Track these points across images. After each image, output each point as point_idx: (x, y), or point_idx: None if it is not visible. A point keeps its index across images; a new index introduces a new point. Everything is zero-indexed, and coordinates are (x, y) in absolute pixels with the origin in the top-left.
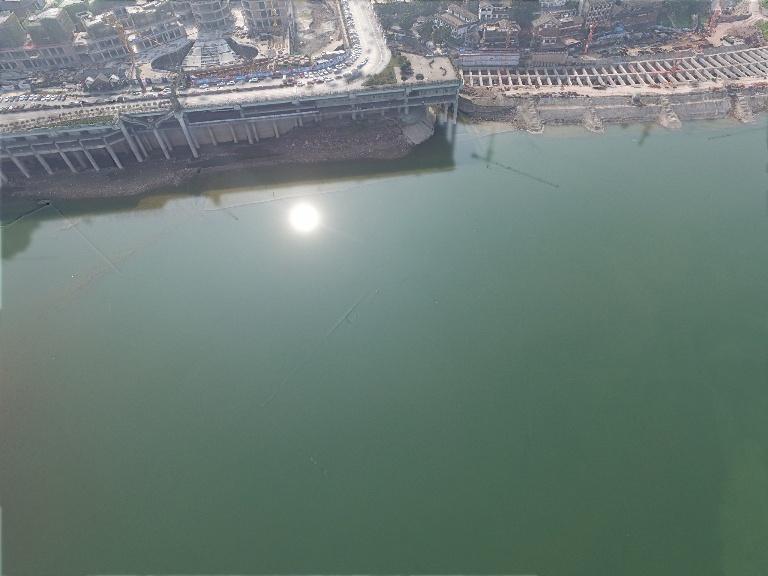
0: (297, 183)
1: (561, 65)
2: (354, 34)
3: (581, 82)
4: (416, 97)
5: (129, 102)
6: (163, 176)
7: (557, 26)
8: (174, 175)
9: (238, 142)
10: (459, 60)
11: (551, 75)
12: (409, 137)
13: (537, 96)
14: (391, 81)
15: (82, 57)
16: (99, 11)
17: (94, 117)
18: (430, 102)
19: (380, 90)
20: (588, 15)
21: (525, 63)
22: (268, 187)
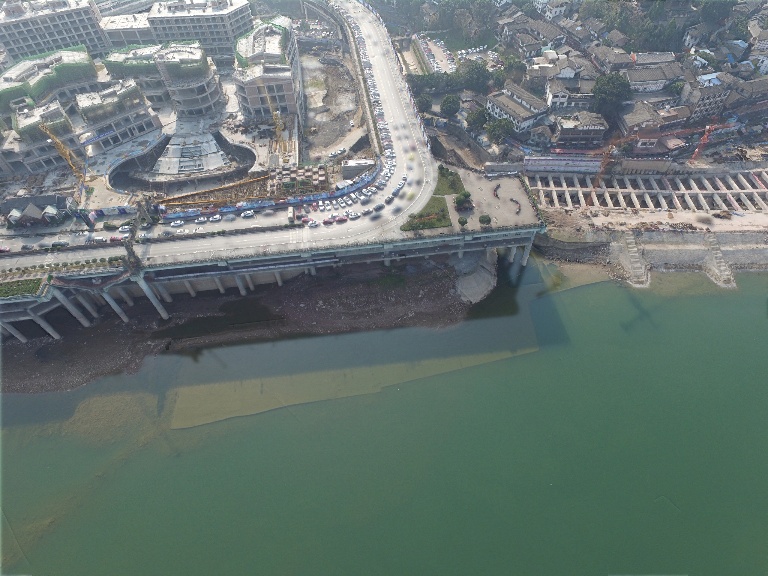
0: (307, 376)
1: (660, 173)
2: (385, 131)
3: (691, 201)
4: (476, 241)
5: (68, 251)
6: (115, 357)
7: (659, 125)
8: (131, 355)
9: (225, 291)
10: (523, 164)
11: (650, 190)
12: (464, 293)
13: (638, 229)
14: (443, 223)
15: (16, 163)
16: (46, 93)
17: (12, 282)
18: (495, 245)
19: (428, 239)
20: (696, 106)
21: (612, 170)
22: (265, 382)
